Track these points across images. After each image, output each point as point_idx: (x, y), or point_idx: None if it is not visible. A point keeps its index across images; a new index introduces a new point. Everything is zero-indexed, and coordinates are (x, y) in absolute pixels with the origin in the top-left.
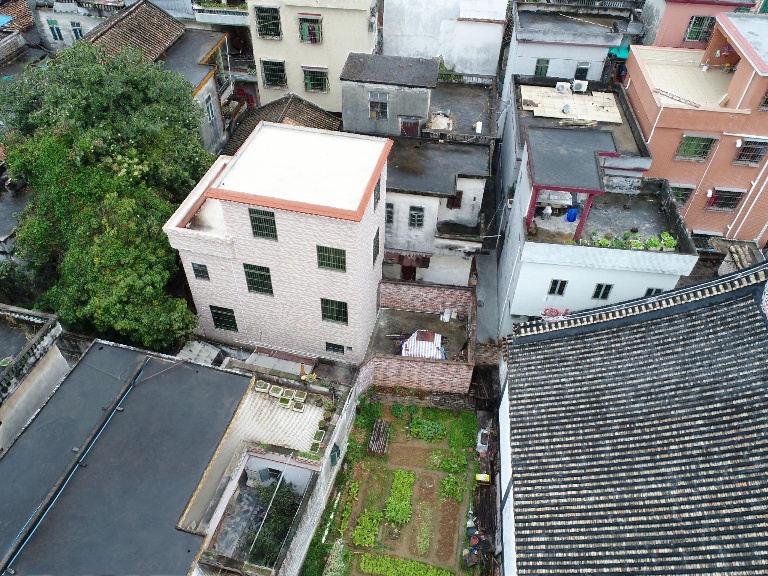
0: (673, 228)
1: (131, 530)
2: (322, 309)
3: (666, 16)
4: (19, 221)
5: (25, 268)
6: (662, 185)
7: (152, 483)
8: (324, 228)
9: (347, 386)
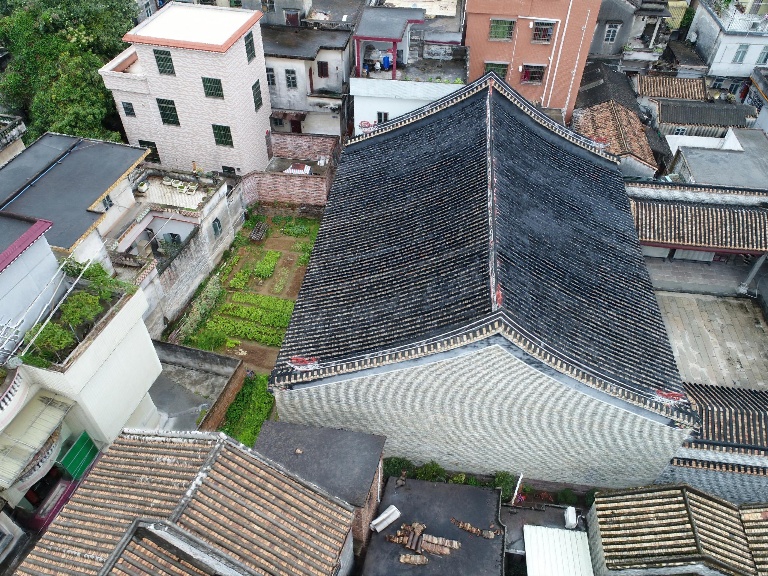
0: (465, 76)
1: (59, 211)
2: (214, 135)
3: None
4: (1, 79)
5: (6, 113)
6: (466, 51)
7: (75, 193)
8: (204, 62)
9: (230, 186)
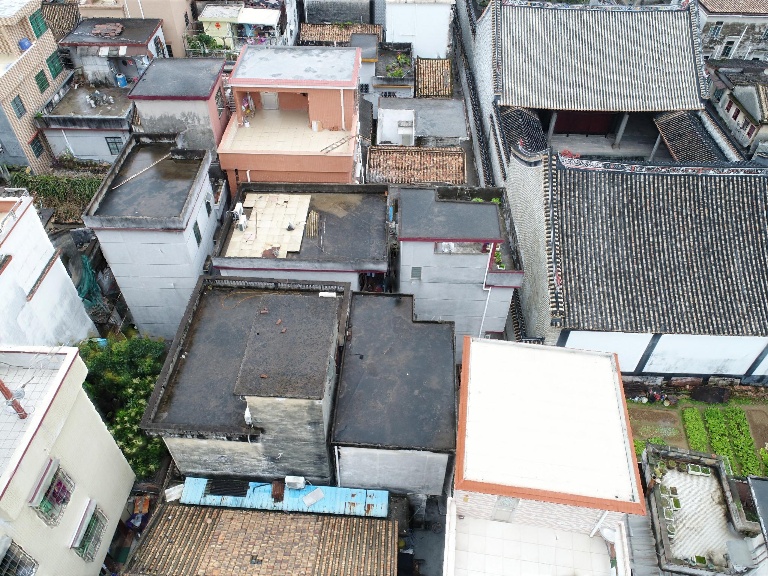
0: (457, 198)
1: None
2: None
3: (210, 111)
4: None
5: None
6: None
7: None
8: None
9: None
